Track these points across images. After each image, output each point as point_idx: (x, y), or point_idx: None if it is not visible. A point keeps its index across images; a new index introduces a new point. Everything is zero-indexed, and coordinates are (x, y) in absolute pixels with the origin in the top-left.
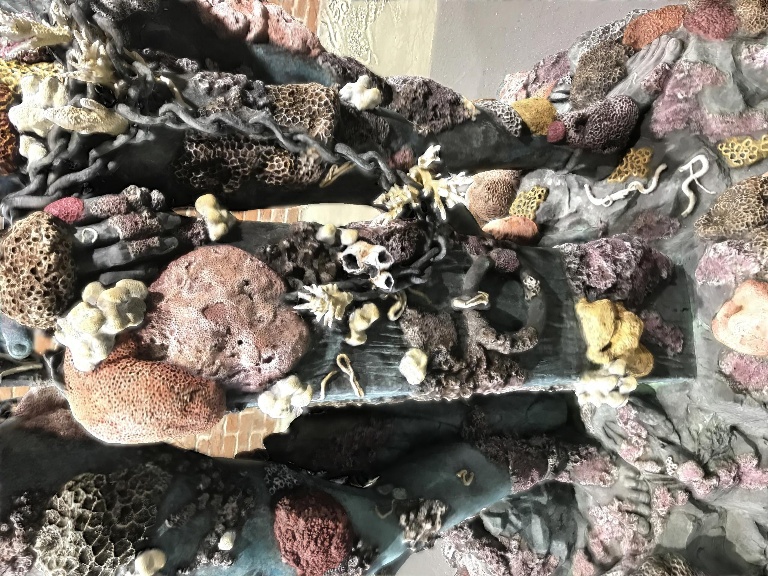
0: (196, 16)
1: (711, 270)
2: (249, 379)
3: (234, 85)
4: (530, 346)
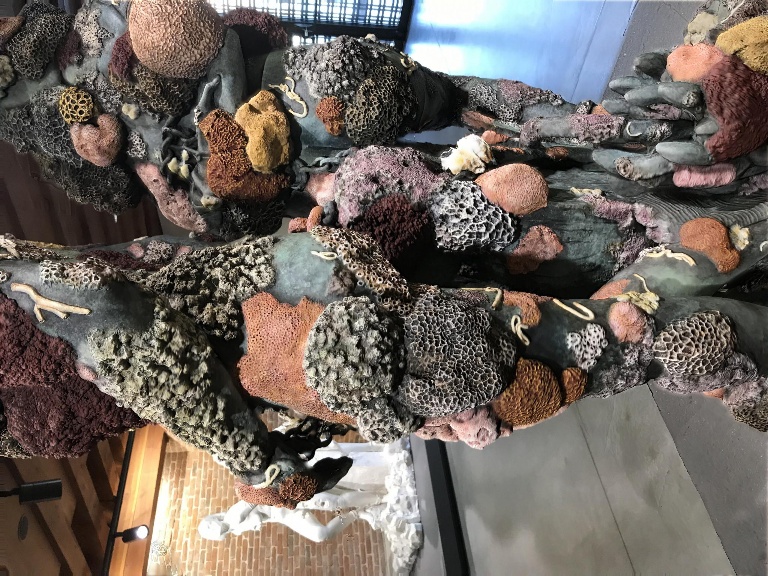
0: None
1: None
2: None
3: None
4: None
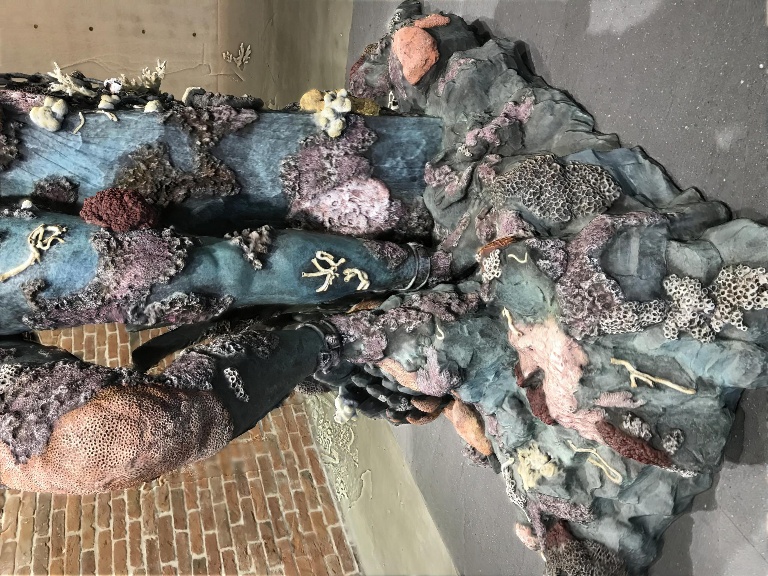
0: None
1: (397, 81)
2: (20, 105)
3: None
4: (248, 99)
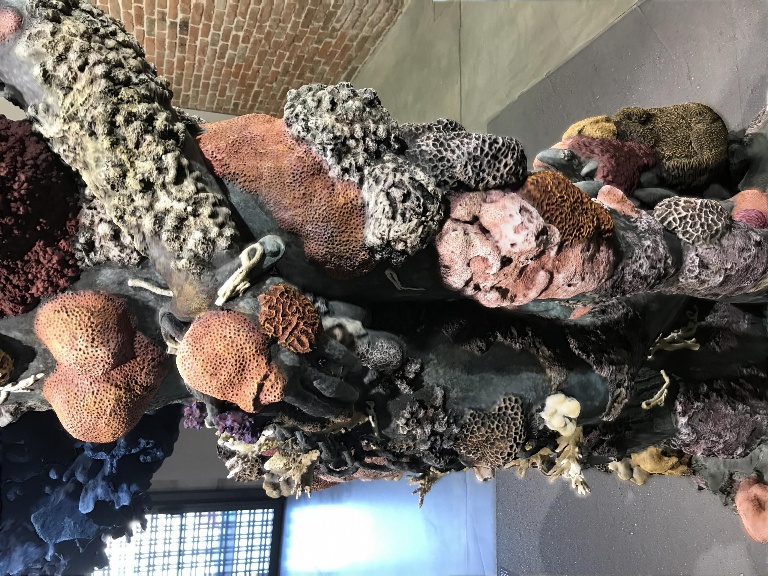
0: (456, 292)
1: None
2: None
3: (428, 439)
4: None
